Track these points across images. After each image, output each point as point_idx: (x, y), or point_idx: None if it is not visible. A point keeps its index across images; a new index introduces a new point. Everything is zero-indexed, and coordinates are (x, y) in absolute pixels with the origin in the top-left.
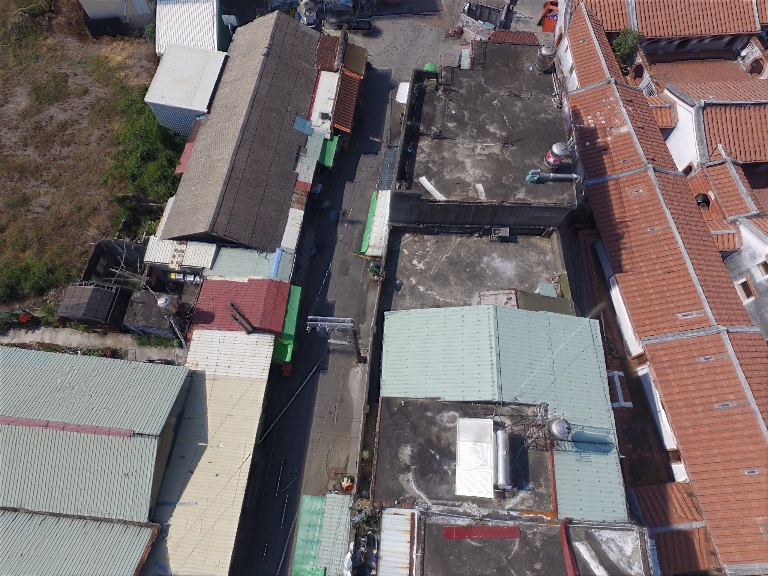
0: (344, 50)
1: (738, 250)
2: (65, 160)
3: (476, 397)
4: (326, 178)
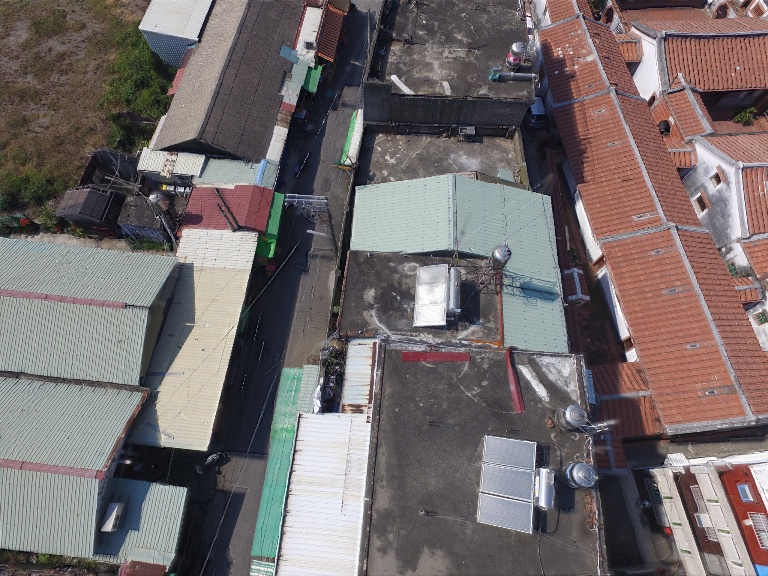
0: None
1: (694, 167)
2: (63, 87)
3: (434, 248)
4: (311, 106)
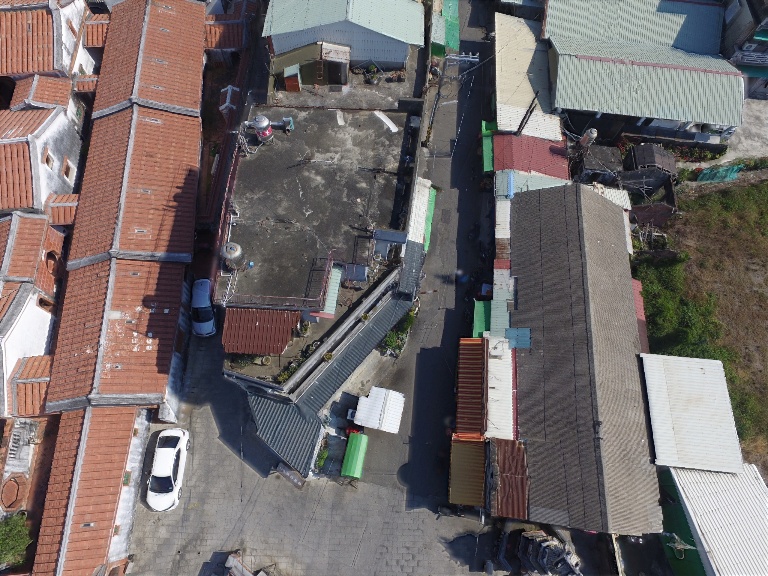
0: None
1: None
2: None
3: None
4: None
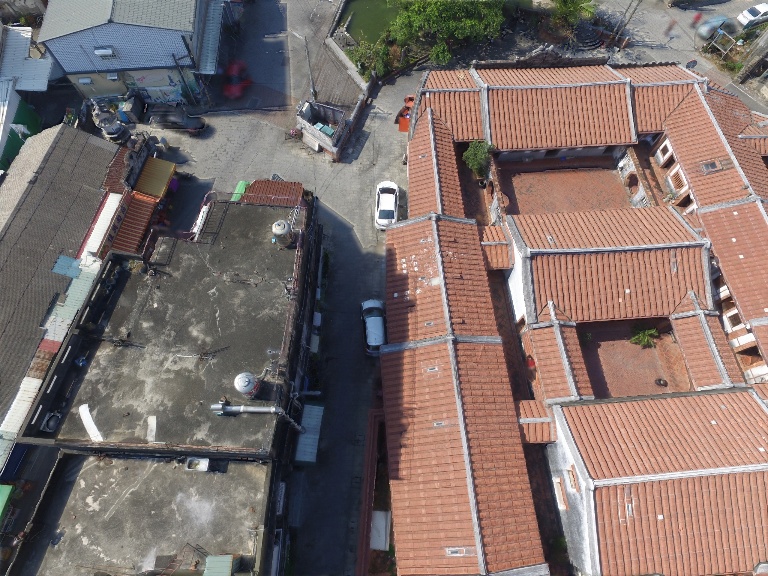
0: (141, 167)
1: (554, 442)
2: None
3: None
4: None
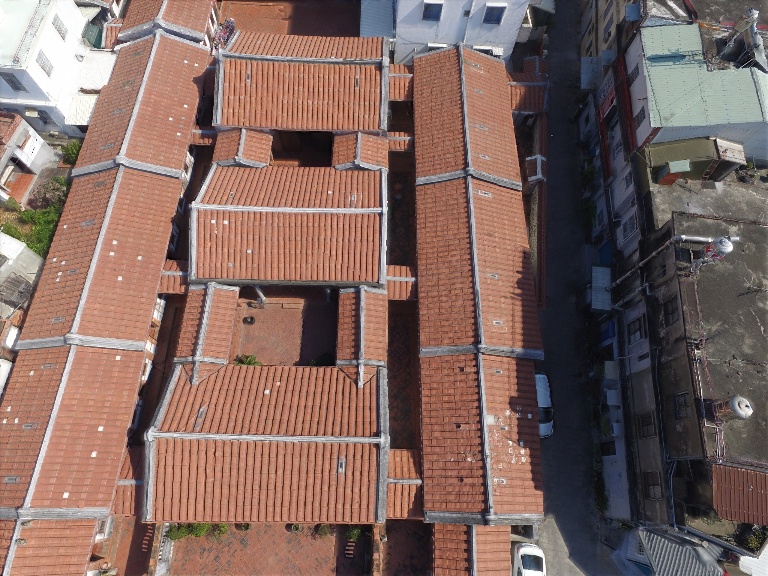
0: None
1: None
2: None
3: (765, 75)
4: None
